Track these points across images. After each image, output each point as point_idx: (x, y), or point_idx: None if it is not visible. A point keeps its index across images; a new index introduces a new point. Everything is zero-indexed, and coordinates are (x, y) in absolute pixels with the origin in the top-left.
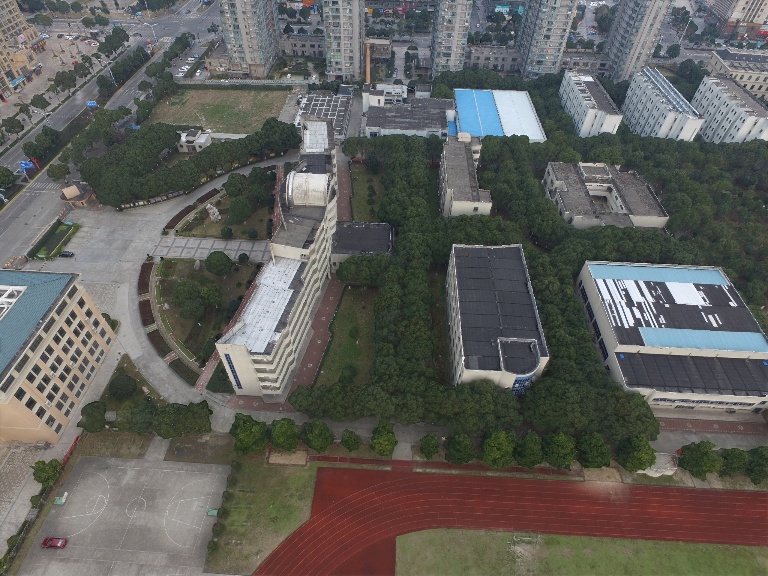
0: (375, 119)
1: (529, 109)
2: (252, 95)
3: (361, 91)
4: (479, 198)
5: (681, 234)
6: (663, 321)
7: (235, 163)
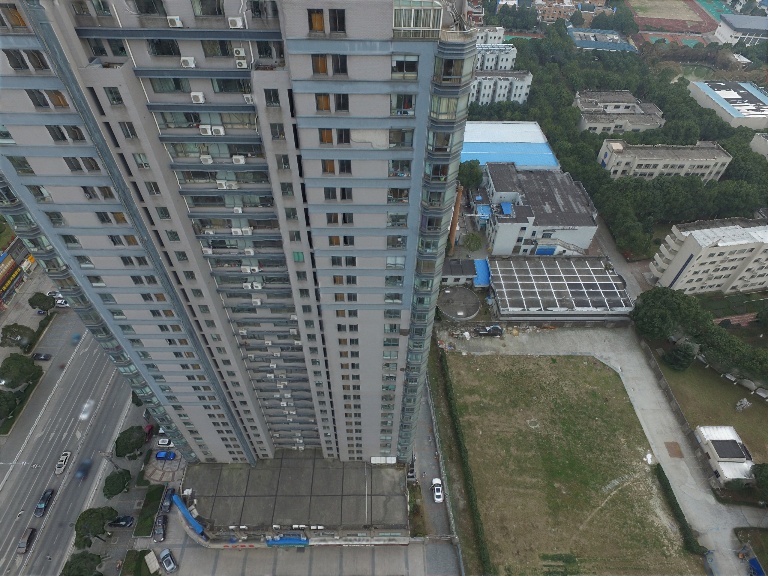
0: (571, 221)
1: (472, 125)
2: (480, 417)
3: (479, 241)
4: (711, 147)
5: (632, 94)
6: (762, 104)
7: (718, 385)
